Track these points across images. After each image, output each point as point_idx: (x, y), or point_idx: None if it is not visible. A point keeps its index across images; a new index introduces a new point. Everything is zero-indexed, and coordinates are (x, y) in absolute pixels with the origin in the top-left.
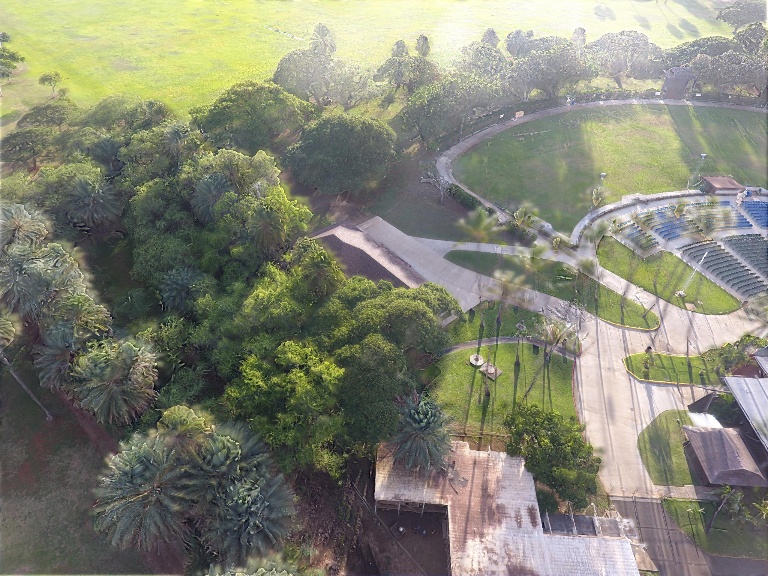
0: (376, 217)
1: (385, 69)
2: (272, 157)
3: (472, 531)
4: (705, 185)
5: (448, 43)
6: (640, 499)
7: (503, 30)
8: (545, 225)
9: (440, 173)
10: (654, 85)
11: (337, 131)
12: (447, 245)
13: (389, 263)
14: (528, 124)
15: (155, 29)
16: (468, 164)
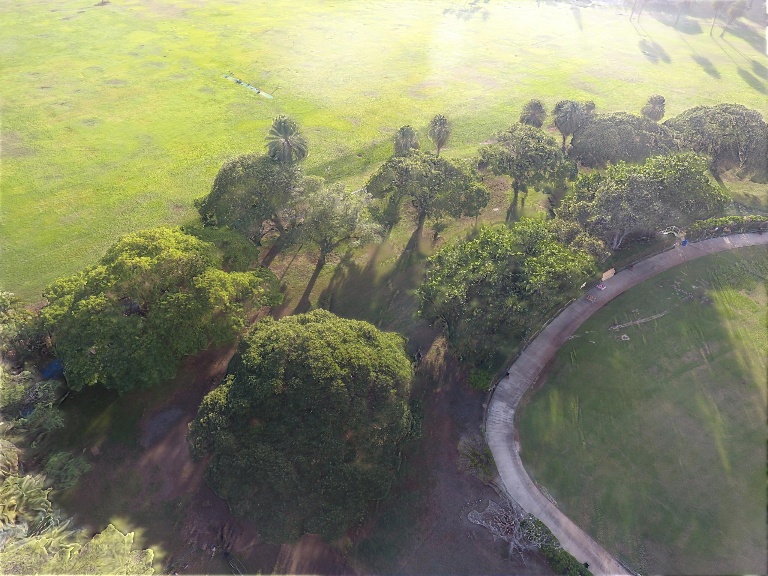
0: None
1: (385, 179)
2: (120, 574)
3: None
4: None
5: (466, 103)
6: None
7: (535, 80)
8: None
9: (498, 456)
10: None
11: (296, 389)
12: None
13: None
14: (627, 298)
15: (76, 79)
16: (546, 423)
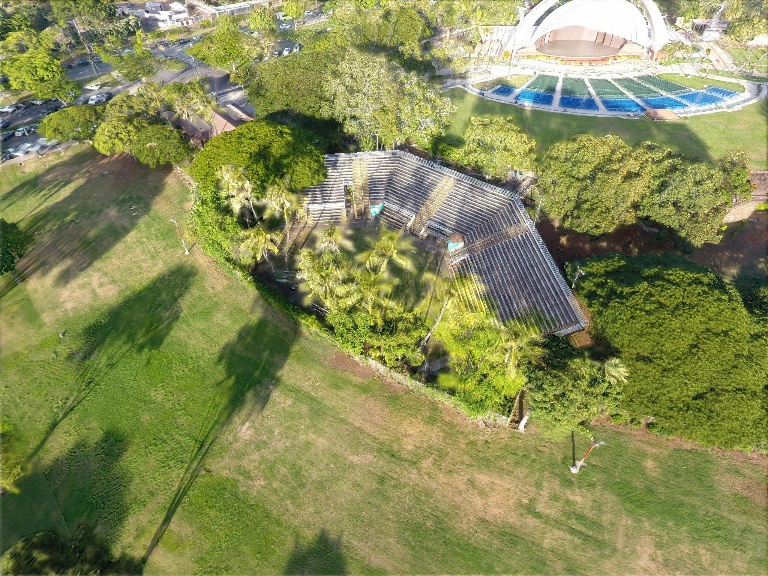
0: None
1: None
2: None
3: None
4: None
5: None
6: None
7: None
8: None
9: None
10: None
11: None
12: None
13: None
14: None
15: None
16: None
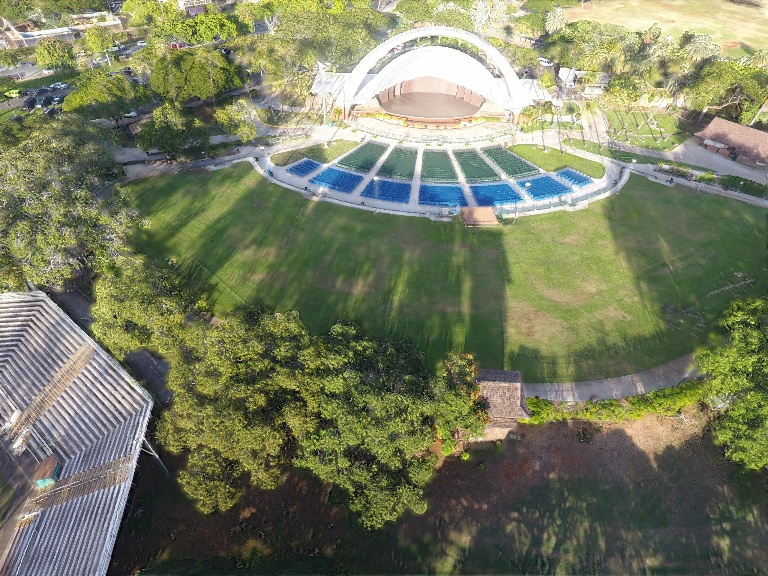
0: None
1: None
2: None
3: (643, 84)
4: (498, 217)
5: None
6: (580, 100)
7: None
8: (655, 179)
9: None
10: None
11: None
12: None
13: (751, 137)
14: None
15: None
16: None
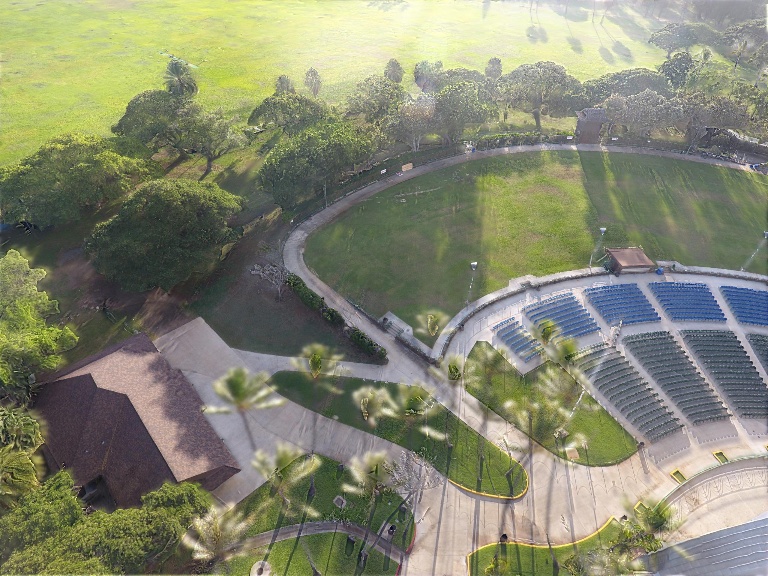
0: (197, 319)
1: (259, 111)
2: (20, 261)
3: None
4: (610, 261)
5: (359, 71)
6: None
7: (424, 55)
8: (404, 329)
9: (288, 255)
10: (575, 121)
11: (151, 207)
12: (275, 362)
13: (164, 414)
14: (415, 180)
15: (30, 55)
16: (327, 240)
